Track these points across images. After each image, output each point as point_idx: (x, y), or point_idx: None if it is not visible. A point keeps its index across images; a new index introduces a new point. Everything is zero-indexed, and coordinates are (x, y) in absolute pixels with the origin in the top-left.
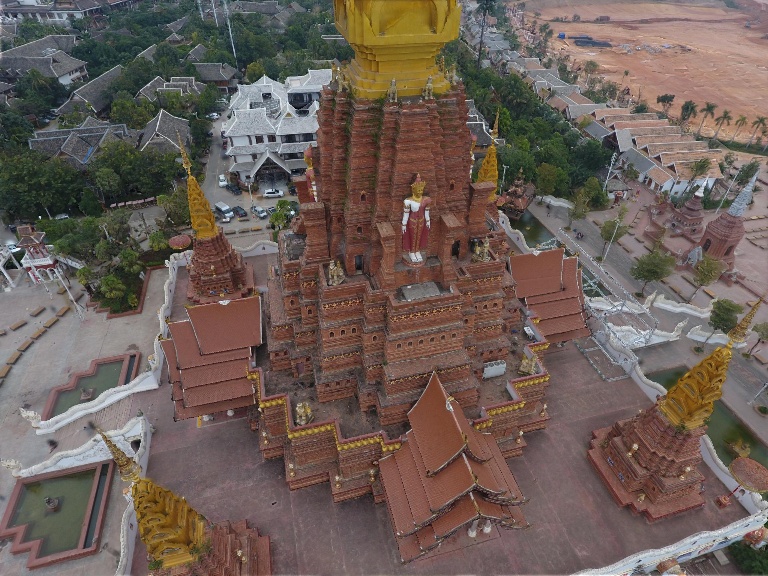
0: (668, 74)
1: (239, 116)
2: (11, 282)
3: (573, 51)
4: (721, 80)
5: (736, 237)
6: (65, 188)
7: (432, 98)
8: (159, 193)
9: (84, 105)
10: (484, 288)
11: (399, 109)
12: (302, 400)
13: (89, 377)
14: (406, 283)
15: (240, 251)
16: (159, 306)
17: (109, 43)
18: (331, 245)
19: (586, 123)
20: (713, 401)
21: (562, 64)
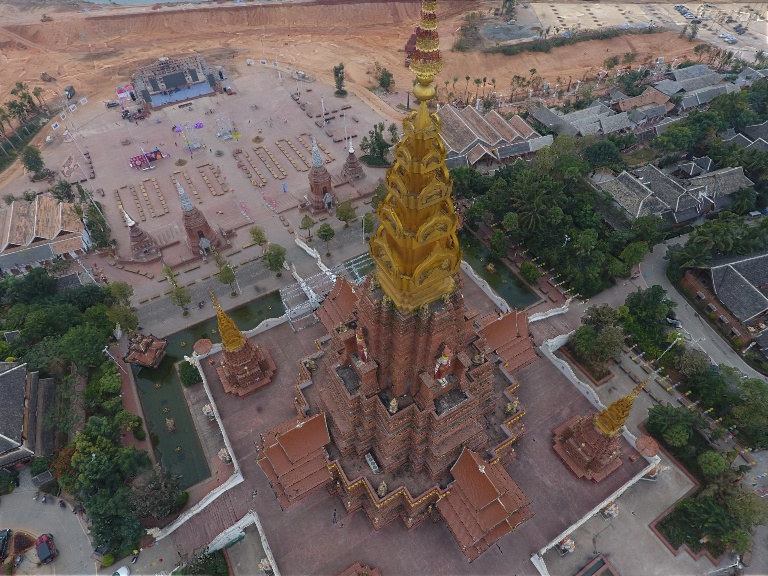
0: None
1: None
2: None
3: None
4: None
5: None
6: None
7: None
8: None
9: None
10: None
11: None
12: (497, 419)
13: None
14: None
15: None
16: None
17: None
18: None
19: None
20: (365, 256)
21: None
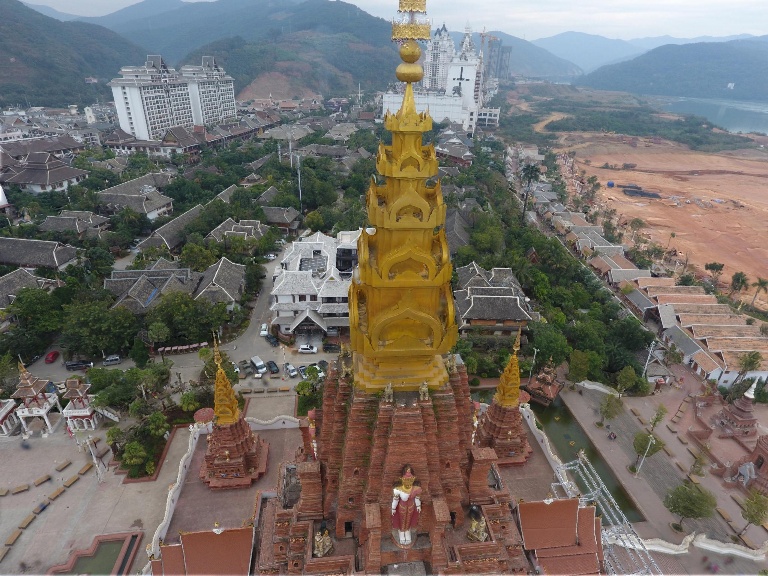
0: (719, 231)
1: (287, 277)
2: (50, 428)
3: None
4: None
5: None
6: (122, 333)
7: (427, 399)
8: (204, 339)
9: (161, 242)
10: (479, 568)
11: (394, 408)
12: None
13: (88, 557)
14: (393, 561)
15: (261, 424)
16: (174, 474)
17: (197, 180)
18: (325, 502)
19: (628, 290)
20: None
21: (609, 217)
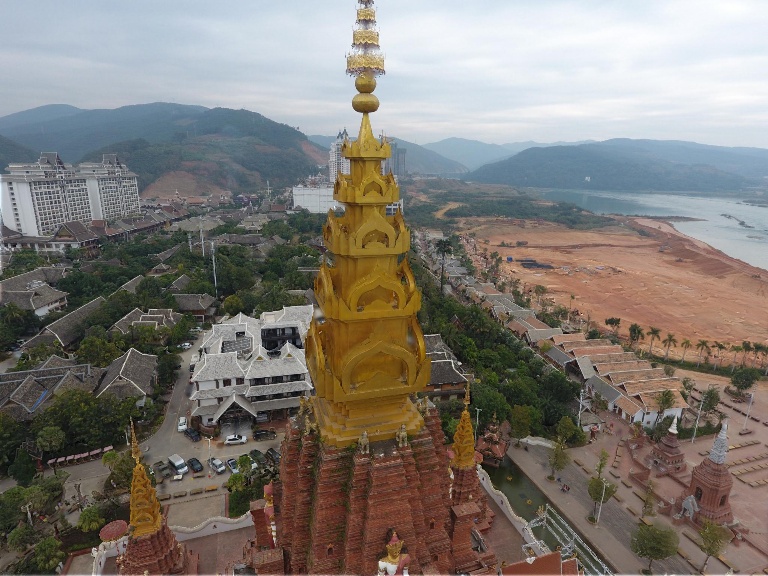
0: (608, 293)
1: (209, 360)
2: None
3: (522, 274)
4: (654, 298)
5: (726, 486)
6: None
7: (406, 445)
8: (108, 443)
9: (53, 339)
10: None
11: (371, 460)
12: None
13: None
14: None
15: (186, 532)
16: None
17: (97, 273)
18: None
19: (547, 348)
20: None
21: (514, 286)
